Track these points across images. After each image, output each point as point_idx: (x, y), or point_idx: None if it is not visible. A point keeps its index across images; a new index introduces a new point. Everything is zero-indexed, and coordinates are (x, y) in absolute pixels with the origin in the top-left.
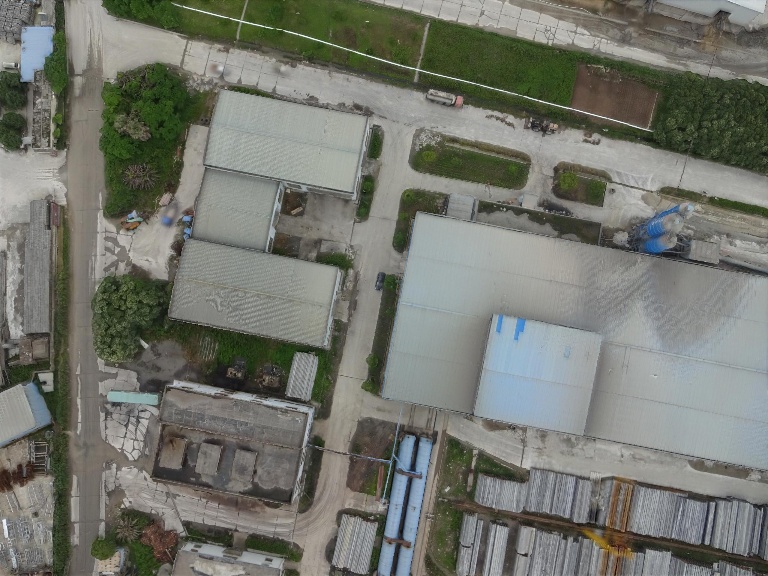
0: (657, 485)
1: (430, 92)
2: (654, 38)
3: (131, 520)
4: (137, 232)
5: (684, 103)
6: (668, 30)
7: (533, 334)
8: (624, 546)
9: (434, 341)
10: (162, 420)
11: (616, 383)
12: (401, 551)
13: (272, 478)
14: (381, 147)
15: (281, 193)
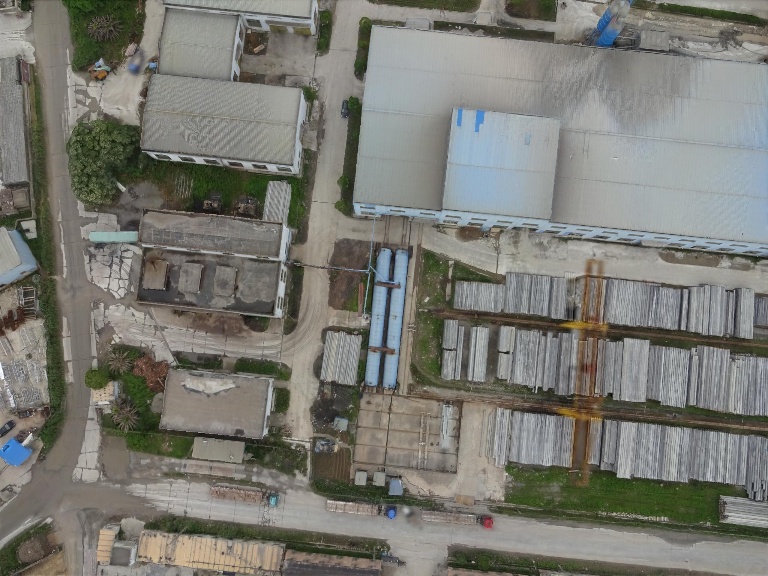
0: (631, 279)
1: None
2: None
3: (122, 353)
4: (106, 83)
5: None
6: None
7: (493, 125)
8: (603, 339)
9: (398, 143)
10: (142, 241)
11: (578, 168)
12: (386, 359)
13: (254, 292)
14: None
15: (242, 32)
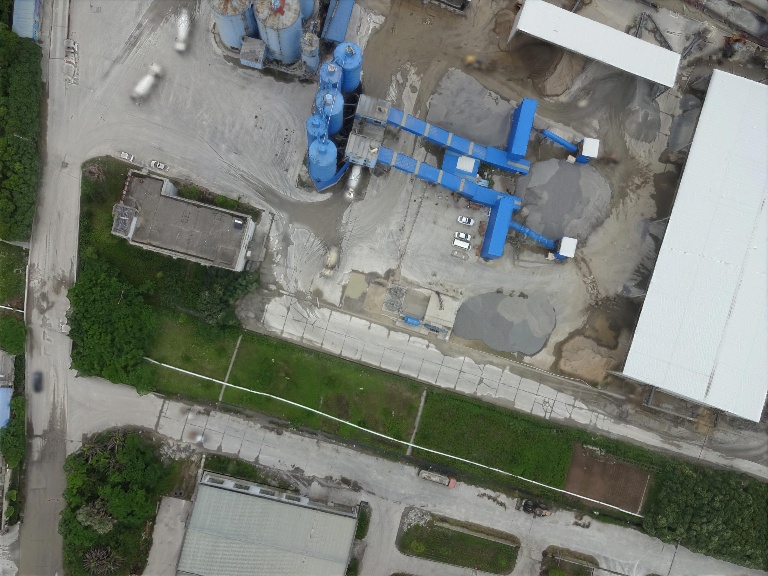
0: None
1: (423, 476)
2: (650, 415)
3: None
4: None
5: (675, 500)
6: (664, 407)
7: None
8: None
9: None
10: None
11: None
12: None
13: None
14: (367, 526)
15: None
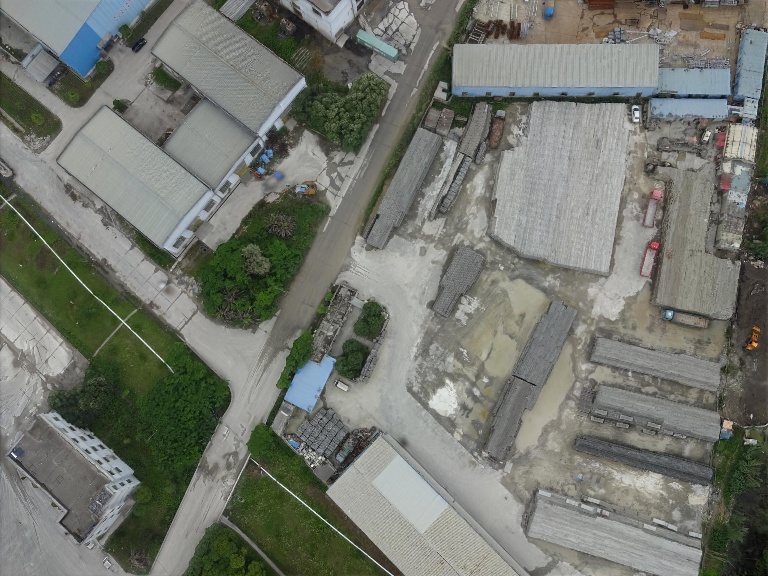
0: None
1: (5, 172)
2: None
3: None
4: None
5: None
6: None
7: None
8: None
9: None
10: None
11: None
12: None
13: None
14: None
15: None
